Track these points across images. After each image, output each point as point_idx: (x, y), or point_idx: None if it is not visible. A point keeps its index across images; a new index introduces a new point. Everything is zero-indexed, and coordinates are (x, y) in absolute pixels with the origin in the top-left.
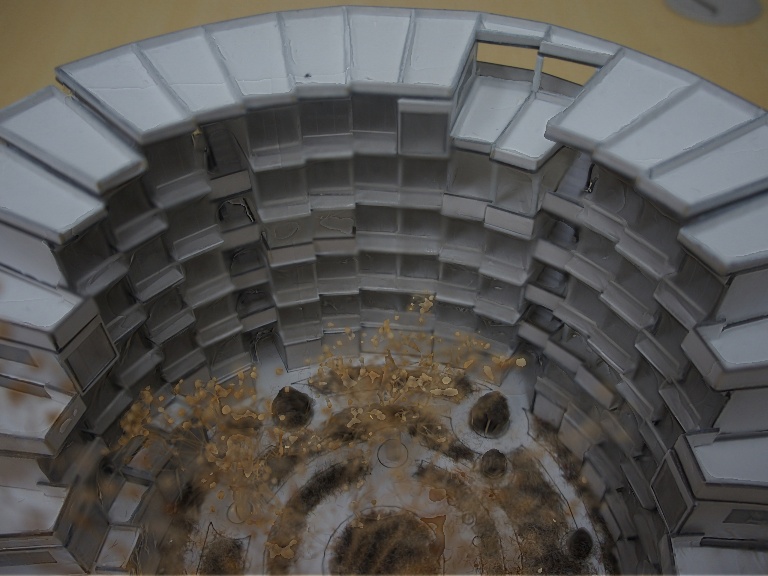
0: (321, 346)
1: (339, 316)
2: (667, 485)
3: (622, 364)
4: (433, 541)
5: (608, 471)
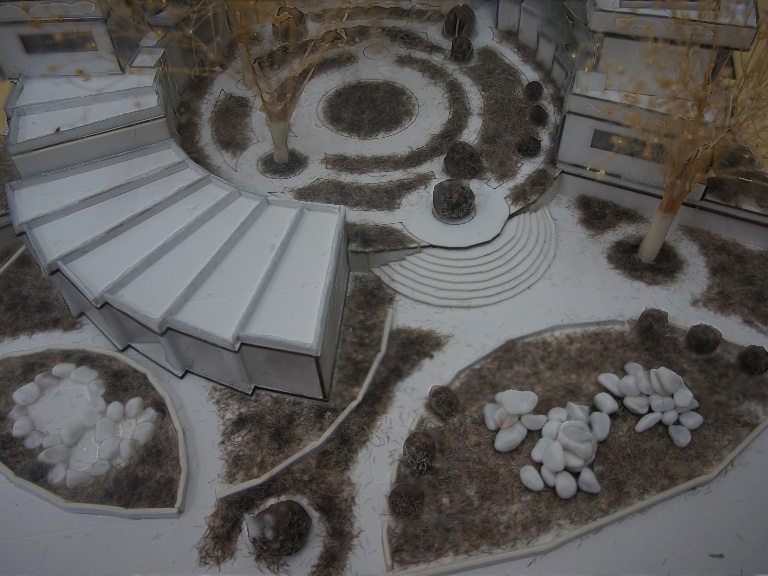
0: None
1: None
2: None
3: None
4: (409, 96)
5: (556, 31)
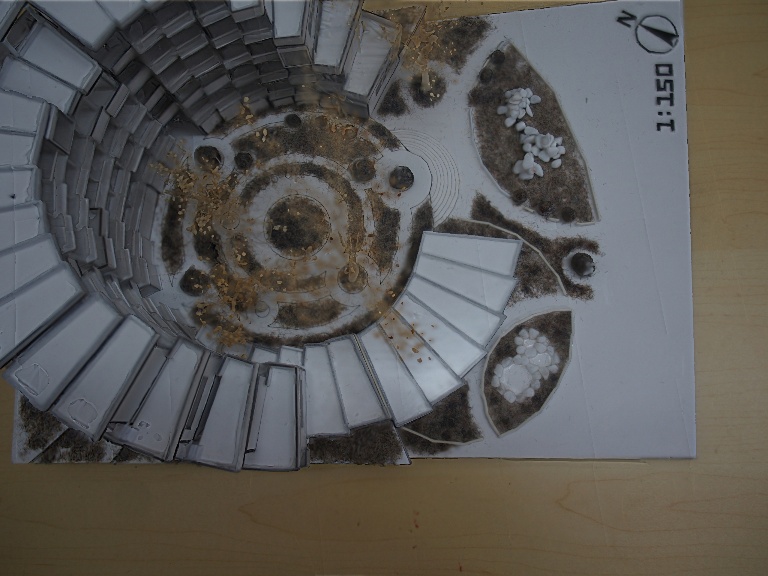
0: (148, 263)
1: (133, 243)
2: (291, 57)
3: (215, 62)
4: (286, 200)
5: (258, 94)
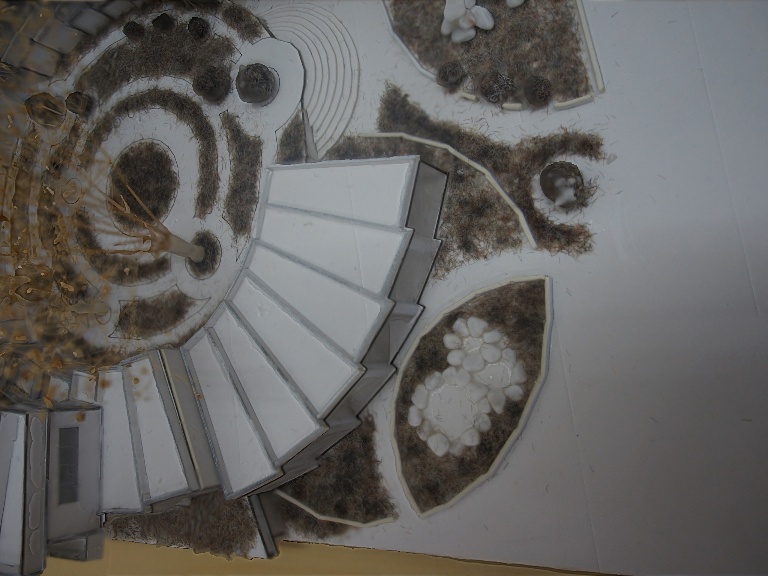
0: None
1: None
2: None
3: None
4: (129, 150)
5: (73, 3)
